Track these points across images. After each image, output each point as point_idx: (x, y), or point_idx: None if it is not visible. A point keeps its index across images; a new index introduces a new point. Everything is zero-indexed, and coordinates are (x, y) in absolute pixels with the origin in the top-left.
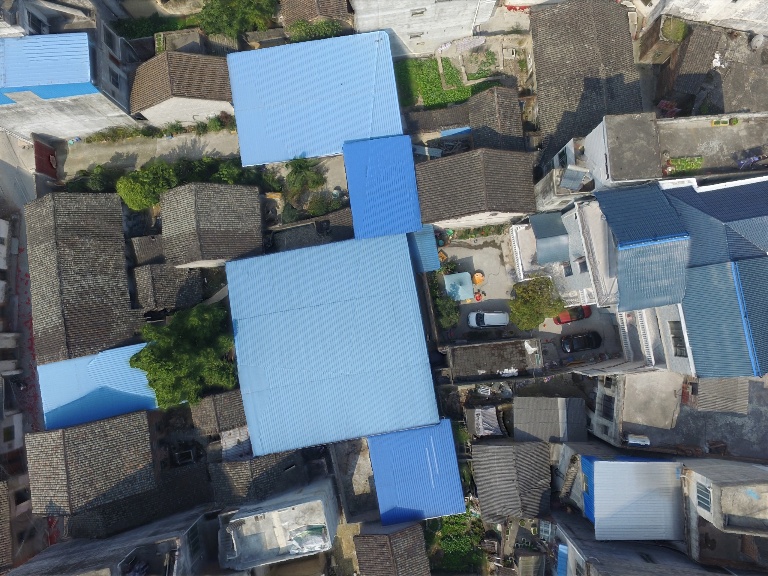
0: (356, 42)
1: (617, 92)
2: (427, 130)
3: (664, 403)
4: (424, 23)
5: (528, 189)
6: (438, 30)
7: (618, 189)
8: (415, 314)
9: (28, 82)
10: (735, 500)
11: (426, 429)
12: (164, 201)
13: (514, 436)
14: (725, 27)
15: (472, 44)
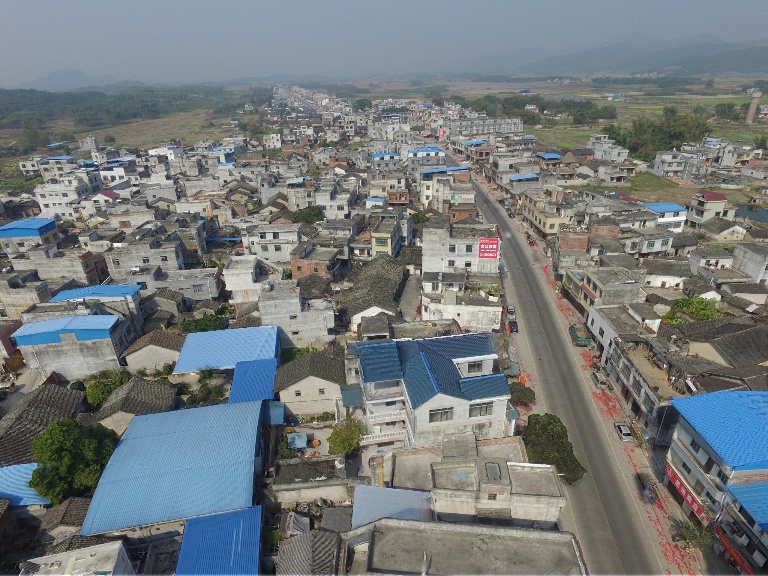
0: (259, 329)
1: None
2: None
3: None
4: (298, 325)
5: (342, 375)
6: (307, 330)
7: None
8: (253, 433)
9: (77, 328)
10: (448, 479)
11: (239, 514)
12: (113, 393)
13: None
14: None
15: (328, 339)
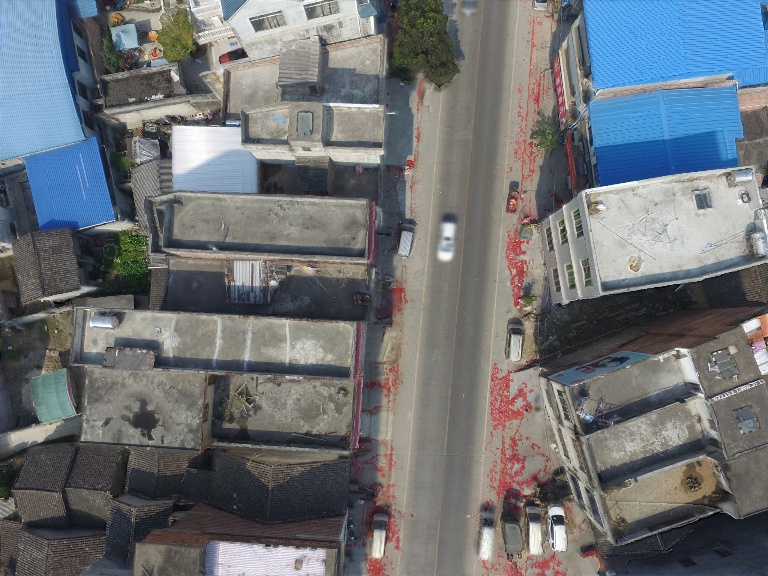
0: None
1: None
2: None
3: (267, 94)
4: None
5: None
6: None
7: None
8: (54, 41)
9: None
10: (264, 126)
11: (75, 147)
12: None
13: (168, 158)
14: None
15: None
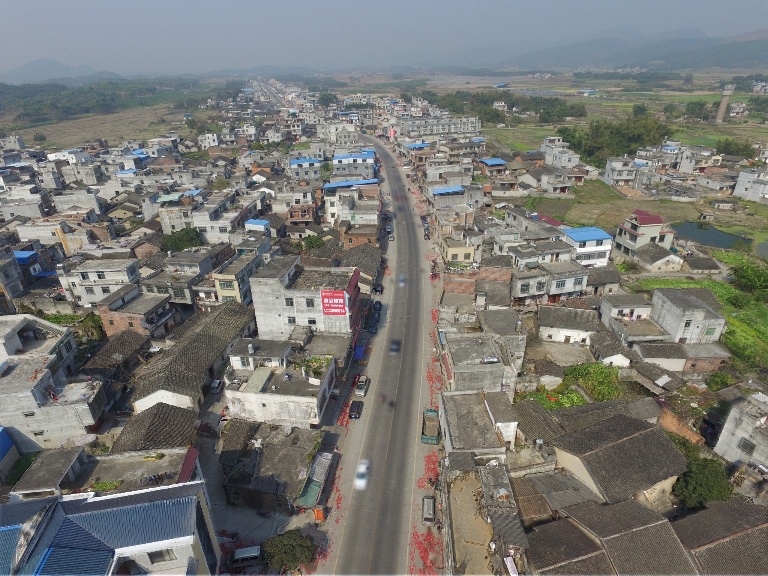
0: None
1: None
2: None
3: None
4: (40, 423)
5: None
6: (56, 429)
7: (21, 501)
8: None
9: None
10: None
11: None
12: None
13: None
14: None
15: (86, 440)
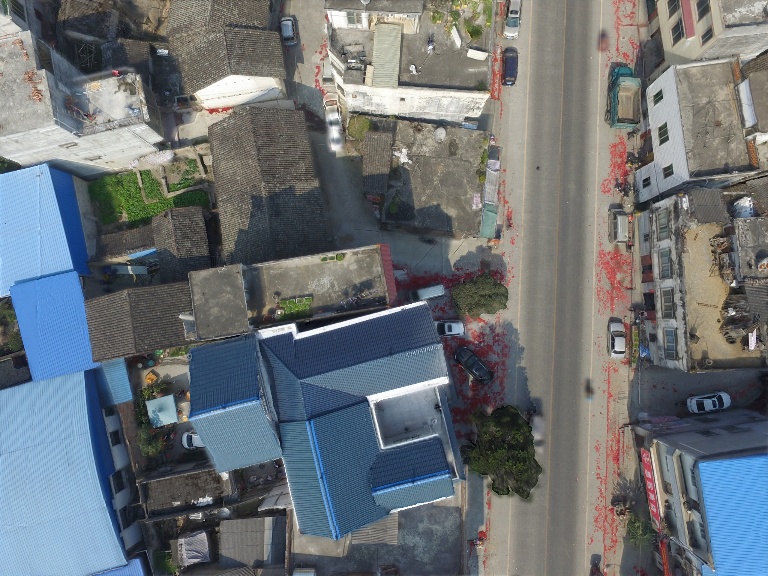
0: (17, 179)
1: (286, 207)
2: (113, 256)
3: None
4: (90, 150)
5: None
6: (115, 152)
7: (214, 344)
8: (88, 458)
9: None
10: None
11: (116, 571)
12: None
13: None
14: (417, 118)
15: (162, 158)
